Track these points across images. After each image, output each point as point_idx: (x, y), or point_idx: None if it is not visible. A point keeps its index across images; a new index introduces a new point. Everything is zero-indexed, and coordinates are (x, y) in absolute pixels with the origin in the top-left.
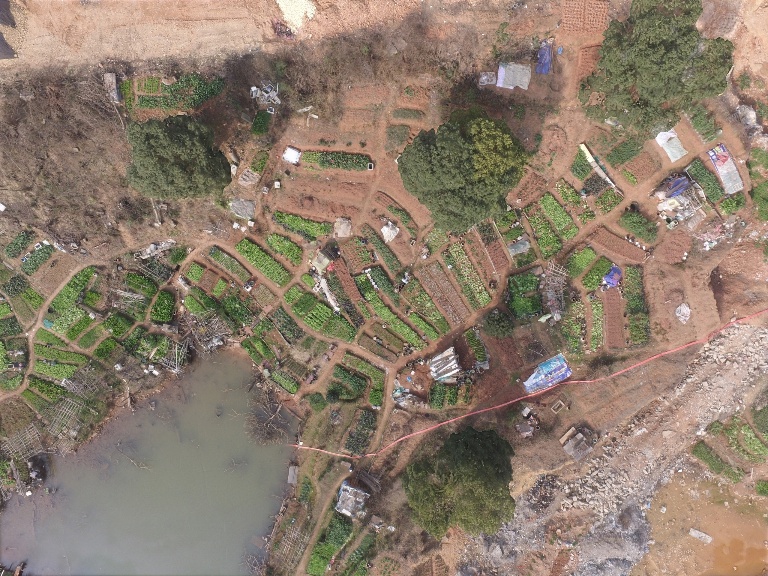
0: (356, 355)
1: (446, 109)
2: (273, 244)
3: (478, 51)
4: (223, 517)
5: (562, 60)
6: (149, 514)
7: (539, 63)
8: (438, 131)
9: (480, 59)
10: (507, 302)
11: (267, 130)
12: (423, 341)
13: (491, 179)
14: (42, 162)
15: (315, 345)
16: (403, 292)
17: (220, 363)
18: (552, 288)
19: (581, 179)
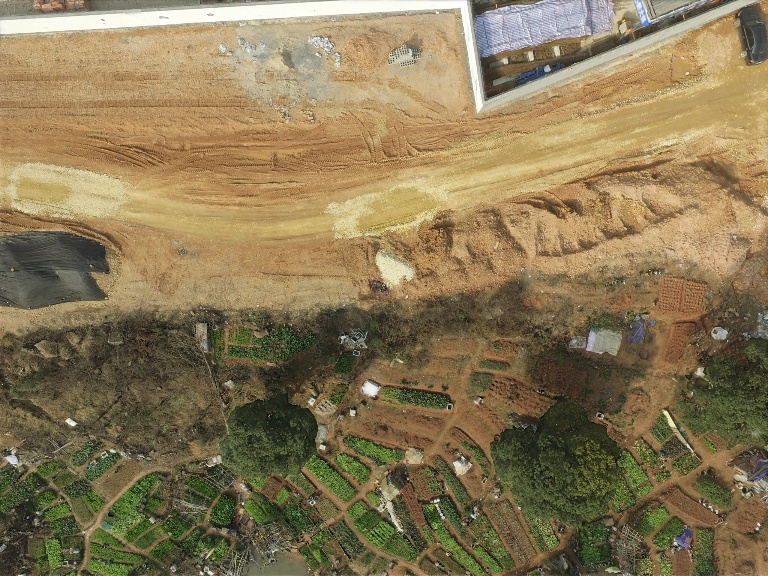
0: (416, 575)
1: (532, 362)
2: (342, 464)
3: (572, 320)
4: None
5: (653, 330)
6: None
7: (631, 334)
8: (541, 443)
9: (573, 327)
10: (576, 551)
11: (350, 370)
12: (486, 573)
13: (593, 503)
14: (121, 393)
15: (375, 561)
16: (471, 527)
17: (276, 566)
18: (625, 551)
19: (661, 442)
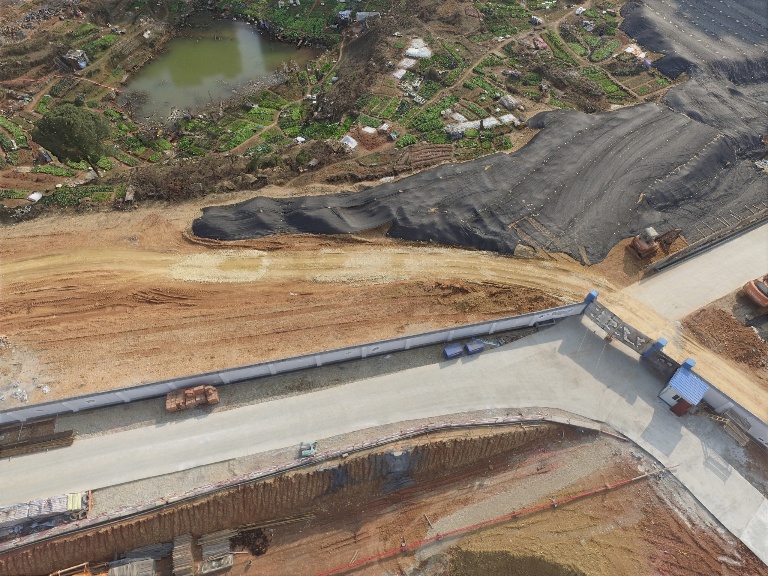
0: None
1: None
2: None
3: None
4: (177, 66)
5: None
6: (221, 66)
7: None
8: None
9: None
10: None
11: None
12: None
13: None
14: None
15: None
16: None
17: None
18: None
19: None
